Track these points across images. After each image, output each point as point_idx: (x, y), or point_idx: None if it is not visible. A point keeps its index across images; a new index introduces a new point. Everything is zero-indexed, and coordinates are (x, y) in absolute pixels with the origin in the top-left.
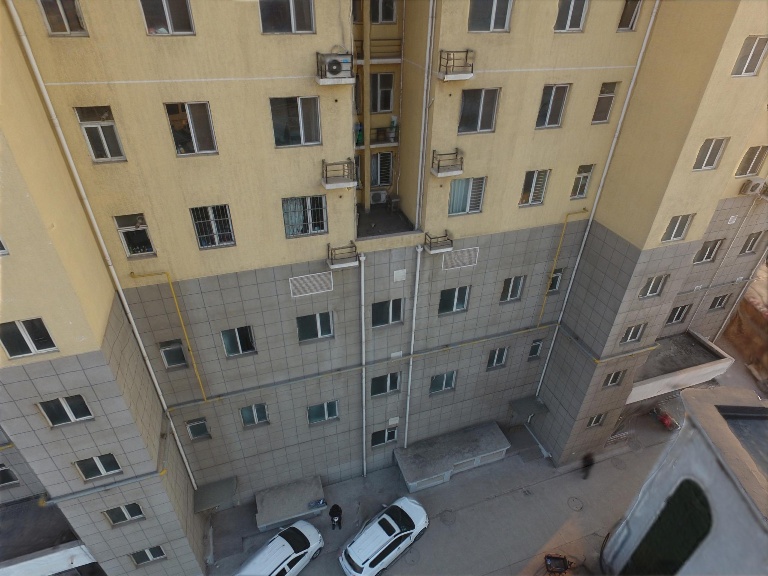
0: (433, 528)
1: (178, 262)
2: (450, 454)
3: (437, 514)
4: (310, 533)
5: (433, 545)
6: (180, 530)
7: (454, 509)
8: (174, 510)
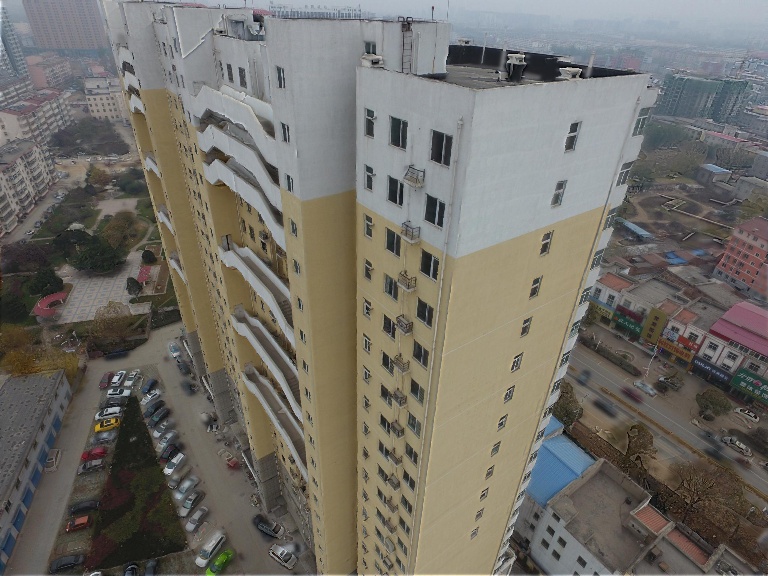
0: (290, 572)
1: (280, 457)
2: (312, 568)
3: (296, 573)
4: (280, 533)
5: (285, 574)
6: (264, 497)
7: (294, 575)
8: (264, 492)
